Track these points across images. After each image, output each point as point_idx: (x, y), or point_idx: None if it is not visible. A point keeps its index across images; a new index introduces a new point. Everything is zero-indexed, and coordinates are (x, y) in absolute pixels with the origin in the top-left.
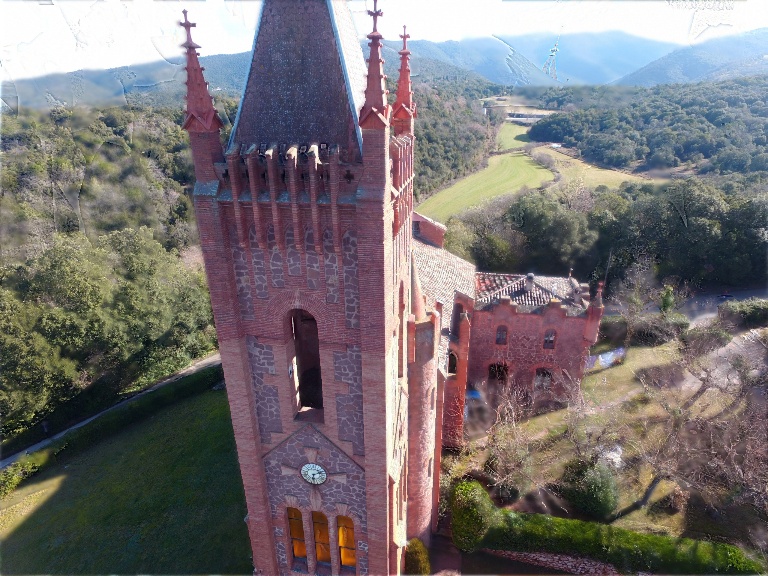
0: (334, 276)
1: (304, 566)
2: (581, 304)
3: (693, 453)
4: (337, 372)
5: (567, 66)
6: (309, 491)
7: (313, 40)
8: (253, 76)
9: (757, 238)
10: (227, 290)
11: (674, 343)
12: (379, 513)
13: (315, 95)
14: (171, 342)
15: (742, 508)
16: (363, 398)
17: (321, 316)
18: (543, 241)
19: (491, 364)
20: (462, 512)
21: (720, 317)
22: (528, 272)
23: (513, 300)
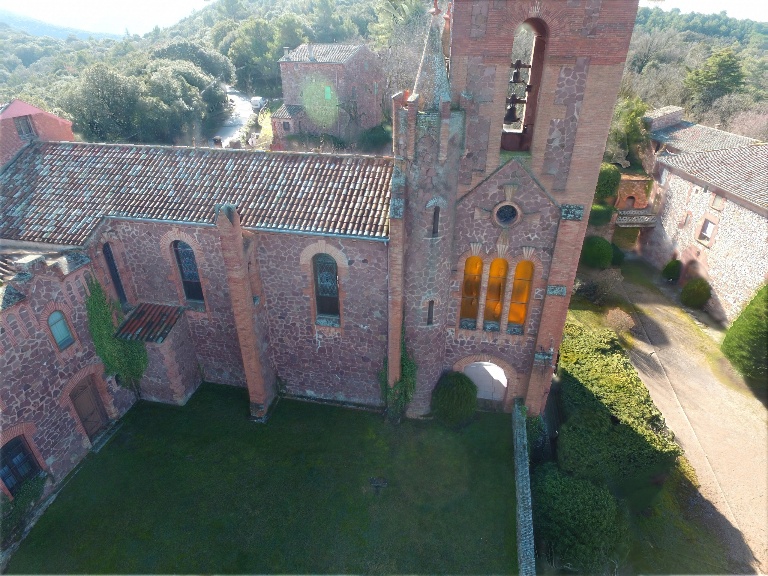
0: None
1: None
2: None
3: None
4: None
5: None
6: None
7: None
8: None
9: (182, 108)
10: None
11: None
12: None
13: None
14: None
15: None
16: None
17: None
18: None
19: None
20: None
21: None
22: None
23: None
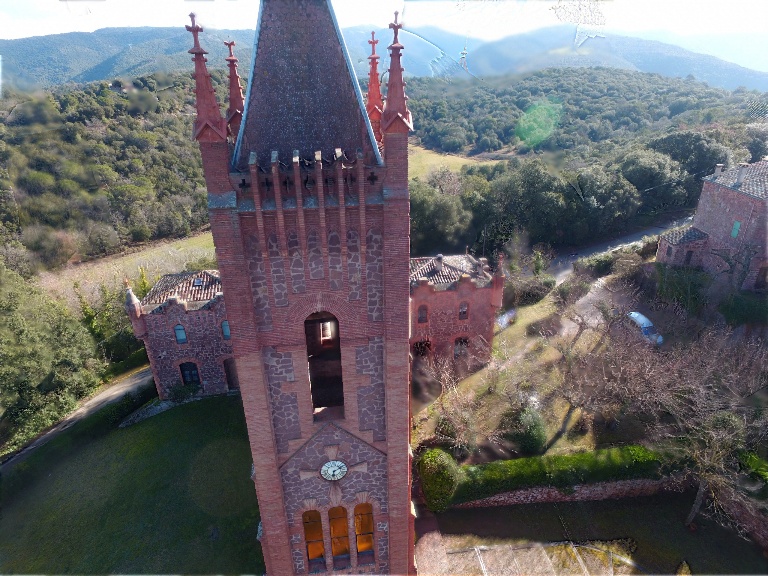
0: (357, 274)
1: (321, 565)
2: (484, 276)
3: (585, 384)
4: (358, 366)
5: (480, 68)
6: (328, 489)
7: (318, 47)
8: (257, 82)
9: (590, 205)
10: (247, 303)
11: (548, 299)
12: (401, 490)
13: (325, 101)
14: (53, 385)
15: (628, 417)
16: (387, 385)
17: (343, 315)
18: (429, 224)
19: (414, 342)
20: (435, 477)
21: (575, 272)
22: (419, 254)
23: (428, 281)
